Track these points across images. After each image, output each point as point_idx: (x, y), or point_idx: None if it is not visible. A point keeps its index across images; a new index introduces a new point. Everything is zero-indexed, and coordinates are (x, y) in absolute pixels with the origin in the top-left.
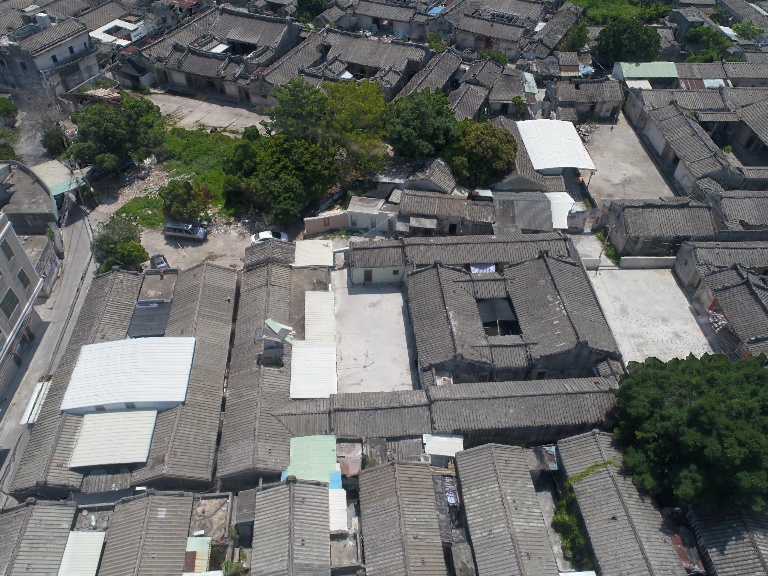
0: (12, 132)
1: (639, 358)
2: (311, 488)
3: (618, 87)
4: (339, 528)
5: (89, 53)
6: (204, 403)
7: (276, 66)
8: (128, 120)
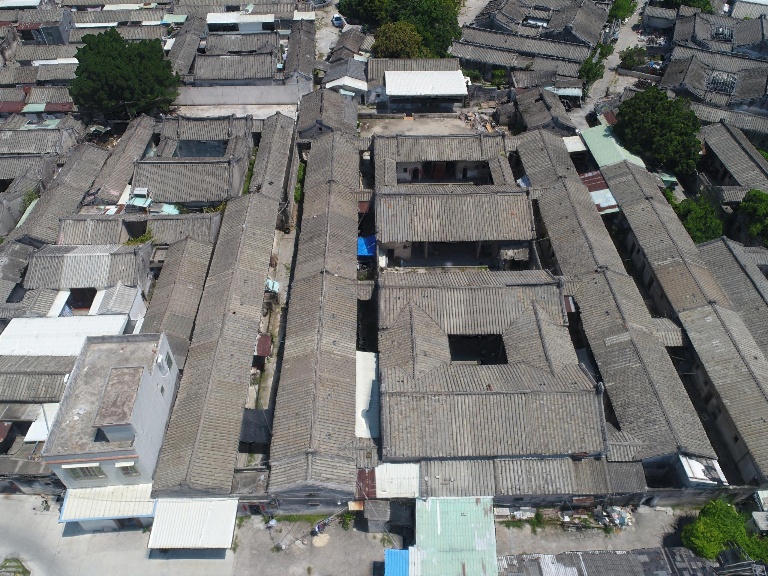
0: None
1: (214, 114)
2: (161, 15)
3: (546, 121)
4: (144, 23)
5: None
6: (213, 1)
7: None
8: None
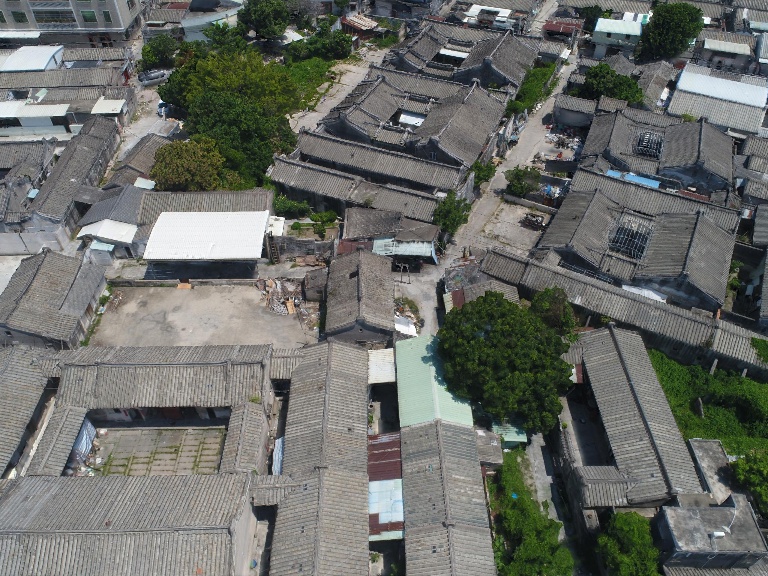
0: (297, 3)
1: None
2: None
3: (350, 320)
4: None
5: (421, 5)
6: (2, 81)
7: (397, 71)
8: (262, 14)
